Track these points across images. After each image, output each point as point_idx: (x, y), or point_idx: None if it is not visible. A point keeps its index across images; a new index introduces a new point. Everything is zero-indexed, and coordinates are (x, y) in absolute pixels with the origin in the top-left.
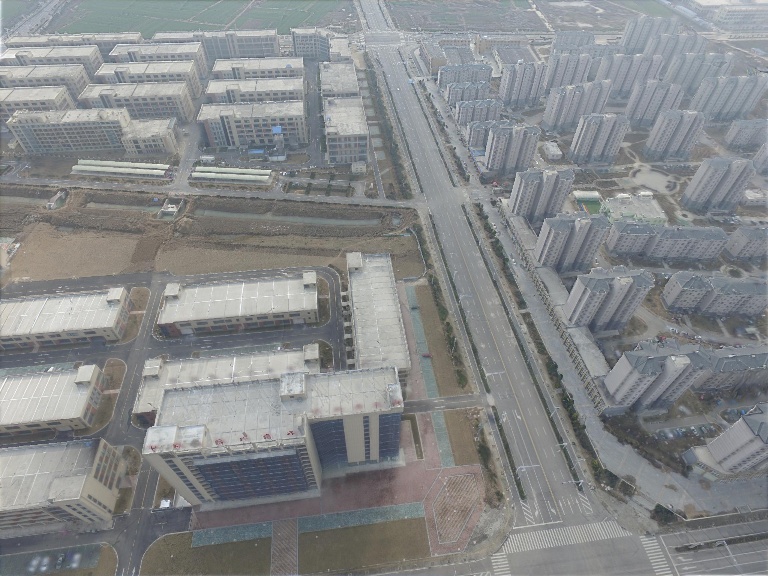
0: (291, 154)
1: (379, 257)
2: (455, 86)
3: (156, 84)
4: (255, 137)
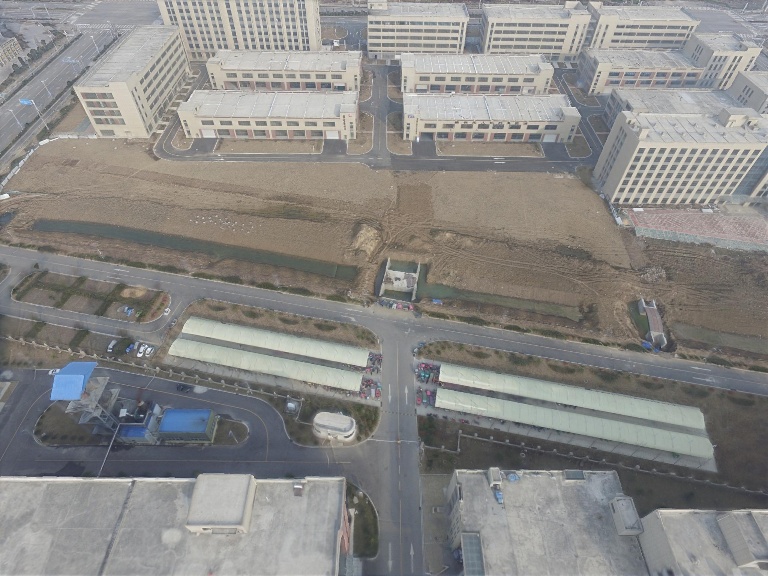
0: (86, 443)
1: None
2: None
3: None
4: None
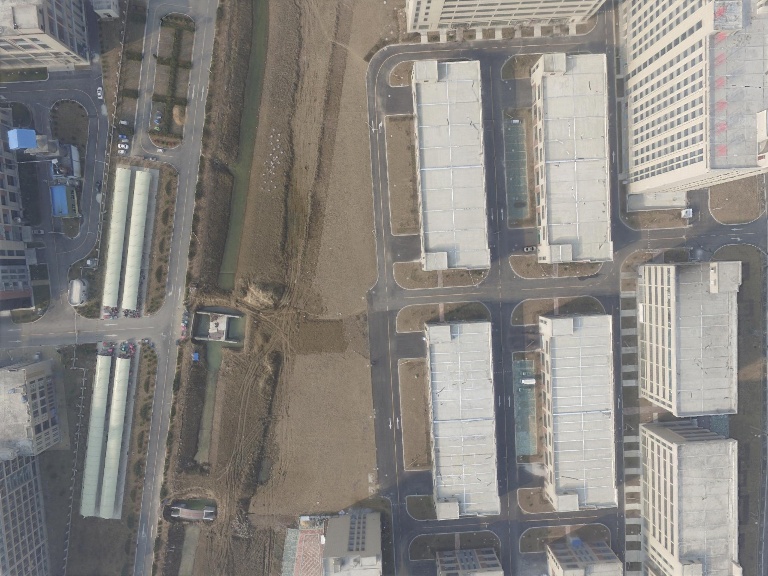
0: (54, 139)
1: None
2: None
3: None
4: (6, 208)
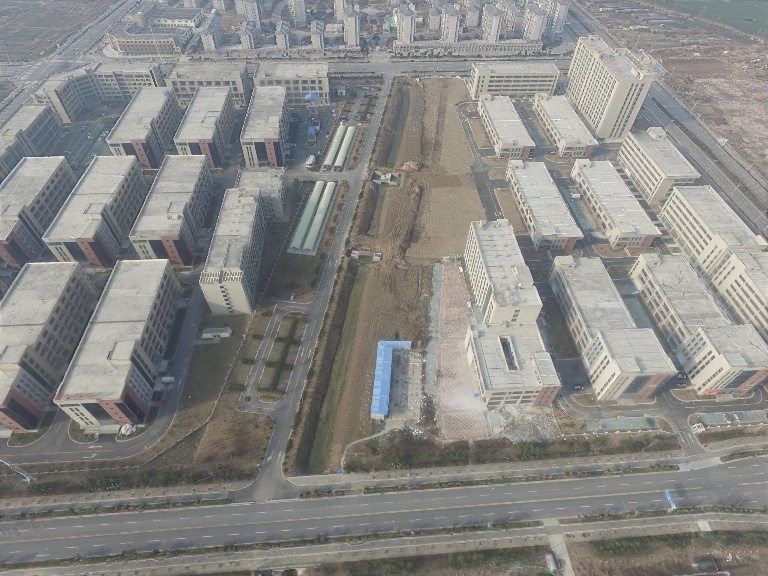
0: None
1: (476, 66)
2: (249, 31)
3: (159, 178)
4: None
